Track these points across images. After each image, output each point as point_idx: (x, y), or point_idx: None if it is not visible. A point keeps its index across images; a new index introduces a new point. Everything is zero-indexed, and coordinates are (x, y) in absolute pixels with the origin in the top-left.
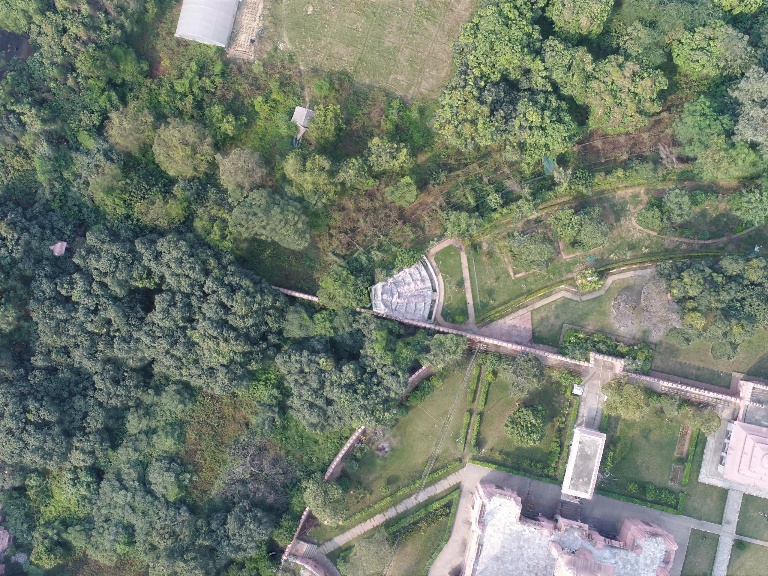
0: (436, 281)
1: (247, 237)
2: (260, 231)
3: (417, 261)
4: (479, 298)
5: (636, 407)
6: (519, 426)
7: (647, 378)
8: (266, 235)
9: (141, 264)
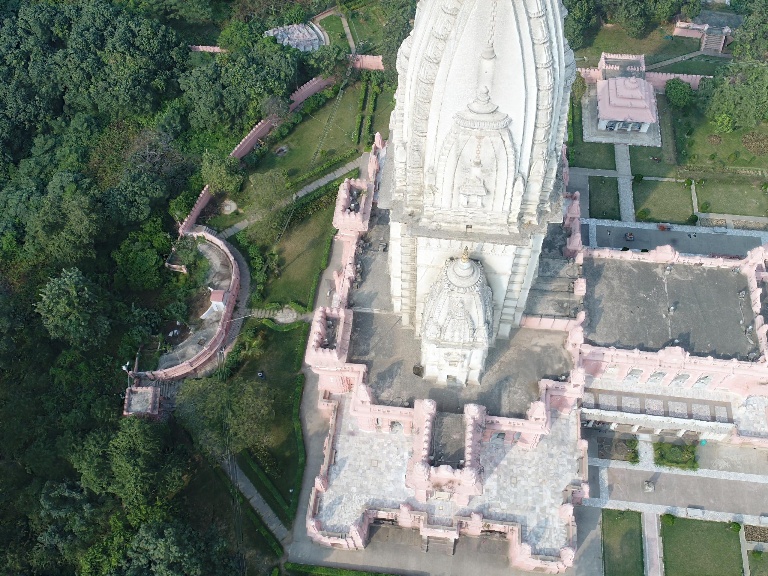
0: (322, 35)
1: (158, 14)
2: (169, 2)
3: (304, 23)
4: None
5: None
6: None
7: None
8: (175, 14)
9: (63, 16)
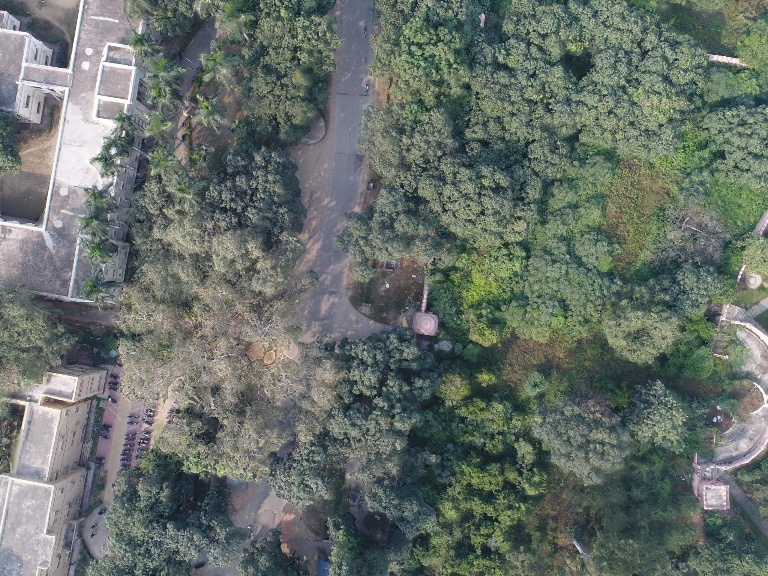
0: None
1: None
2: None
3: None
4: None
5: None
6: None
7: None
8: None
9: (578, 24)
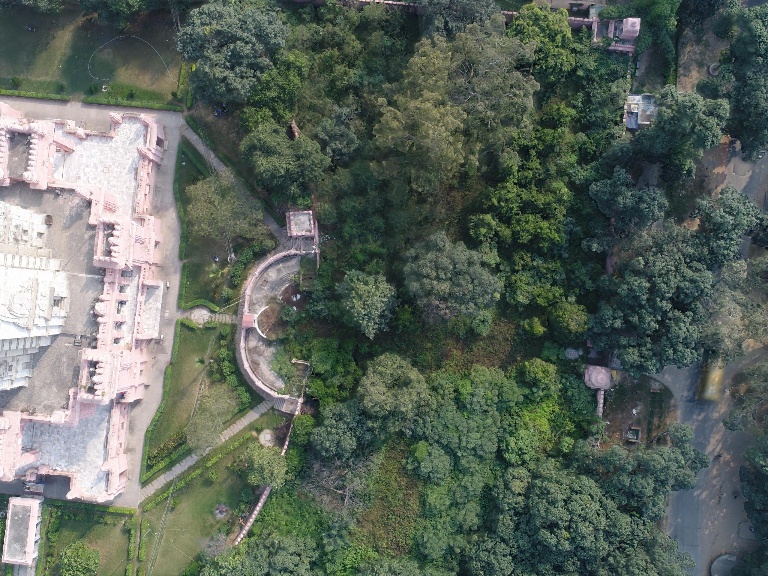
0: None
1: None
2: None
3: None
4: None
5: None
6: None
7: None
8: None
9: None
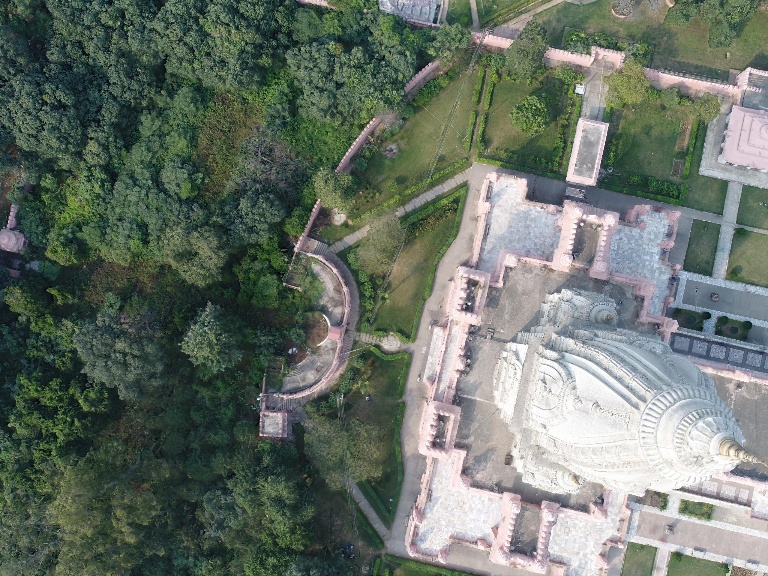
0: None
1: None
2: None
3: None
4: (483, 3)
5: (637, 80)
6: (524, 109)
7: (647, 68)
8: None
9: None
